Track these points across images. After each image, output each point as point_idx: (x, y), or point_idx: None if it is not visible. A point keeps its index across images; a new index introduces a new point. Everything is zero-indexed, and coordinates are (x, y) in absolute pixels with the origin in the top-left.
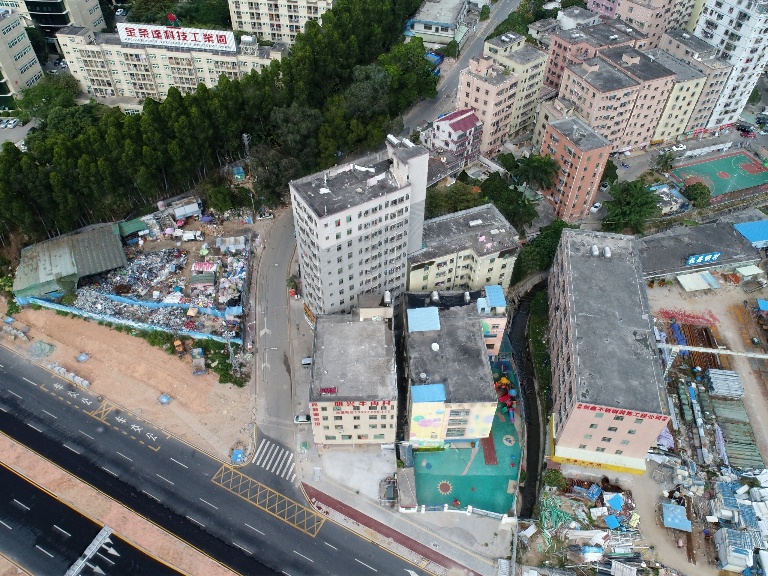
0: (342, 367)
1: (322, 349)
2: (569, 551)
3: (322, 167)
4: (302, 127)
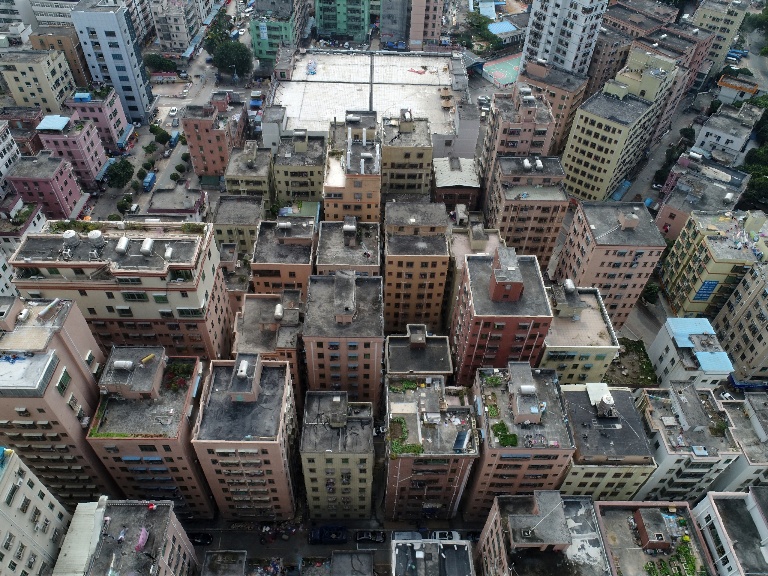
0: None
1: None
2: None
3: None
4: None
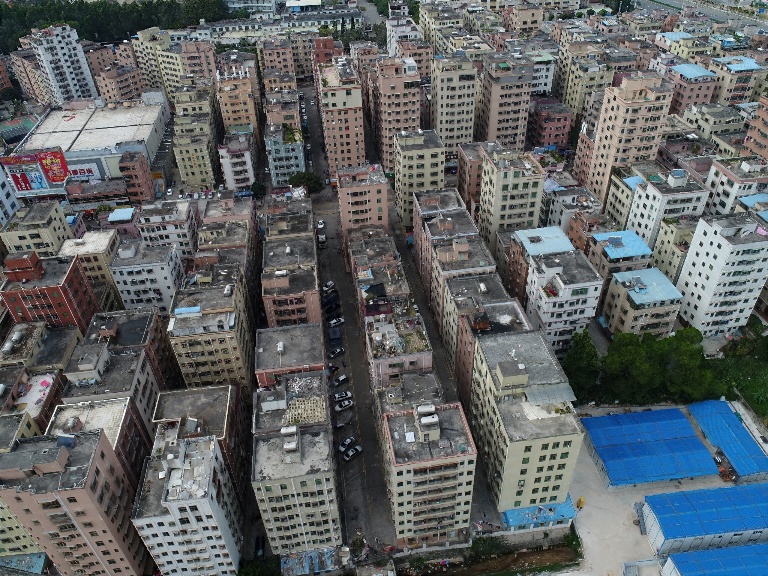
0: None
1: None
2: None
3: None
4: (1, 27)
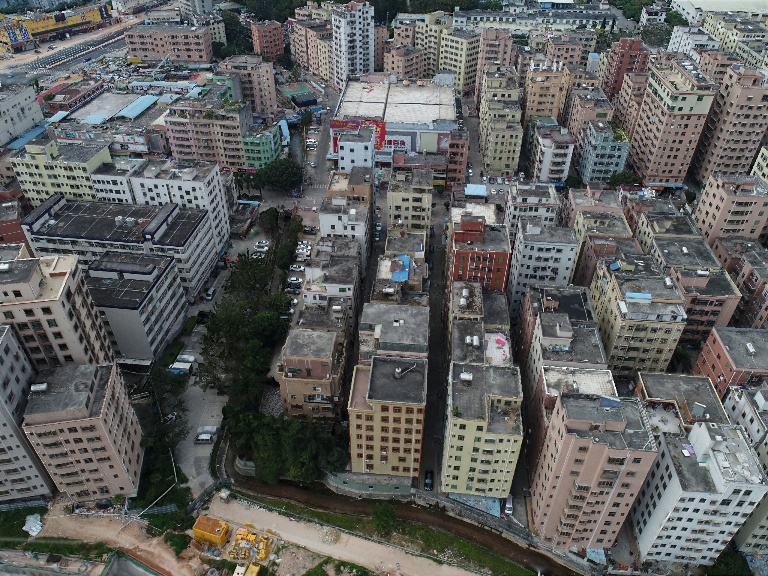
0: None
1: (165, 11)
2: None
3: None
4: None
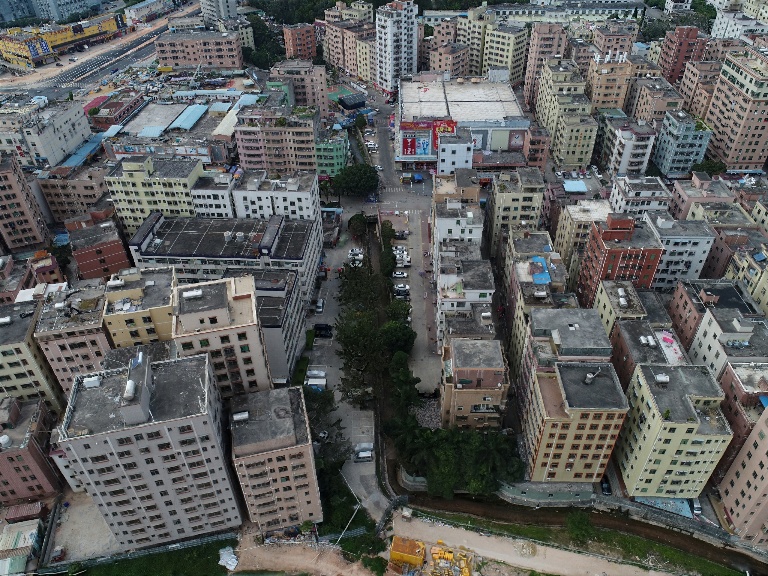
0: None
1: None
2: None
3: (294, 20)
4: None
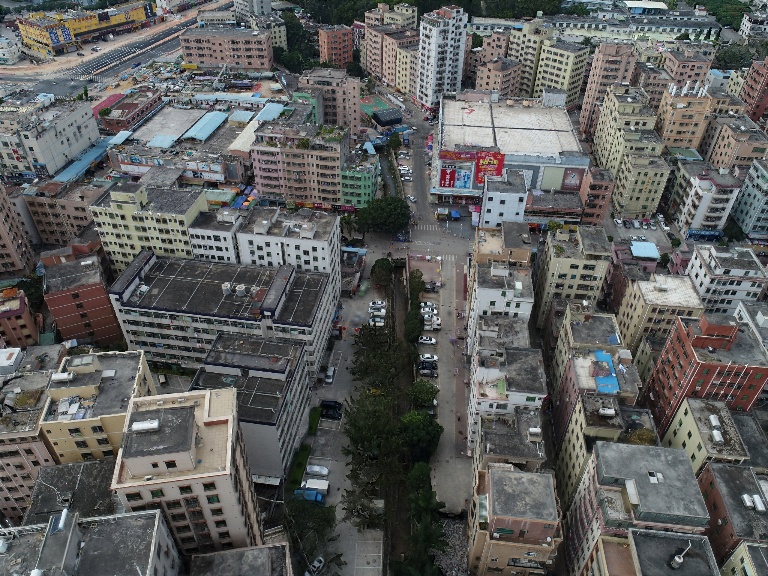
0: (211, 13)
1: None
2: (165, 67)
3: (332, 20)
4: None
